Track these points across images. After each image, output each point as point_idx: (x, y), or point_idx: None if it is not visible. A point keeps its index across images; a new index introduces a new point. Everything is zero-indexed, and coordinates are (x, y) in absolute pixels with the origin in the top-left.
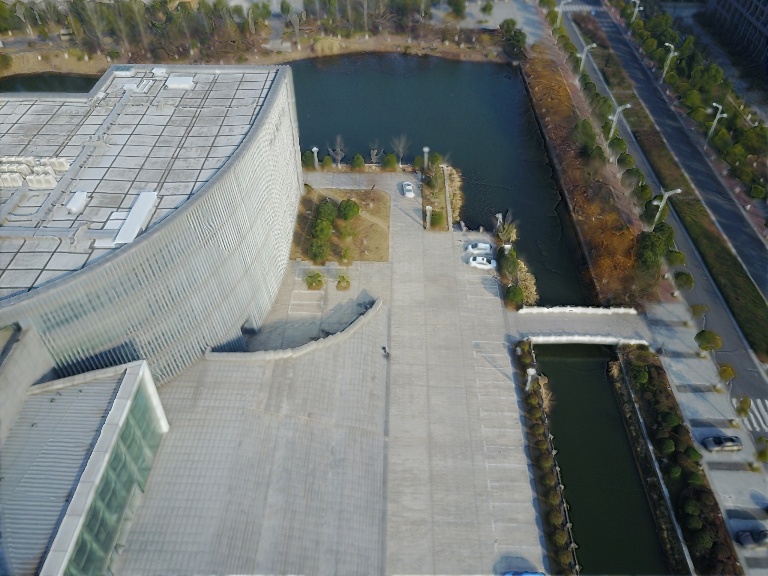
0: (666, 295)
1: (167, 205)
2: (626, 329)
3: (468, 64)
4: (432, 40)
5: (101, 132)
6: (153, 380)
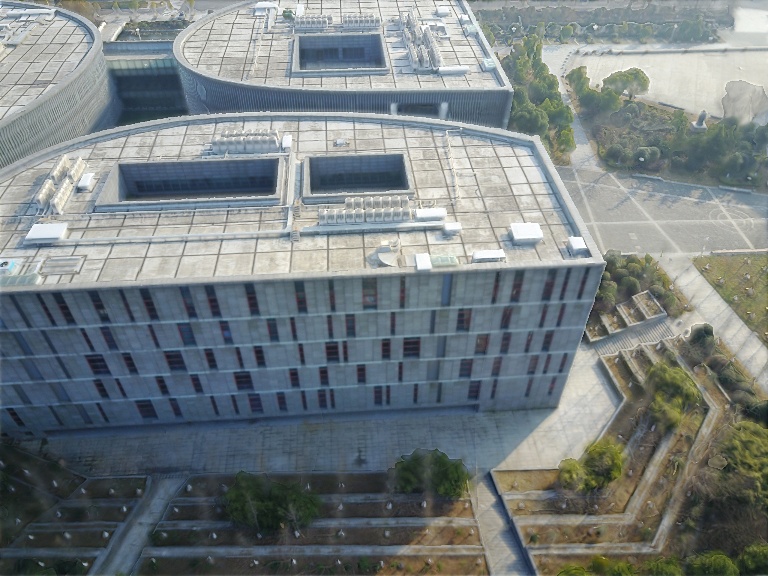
0: (97, 18)
1: None
2: (115, 26)
3: None
4: None
5: None
6: None
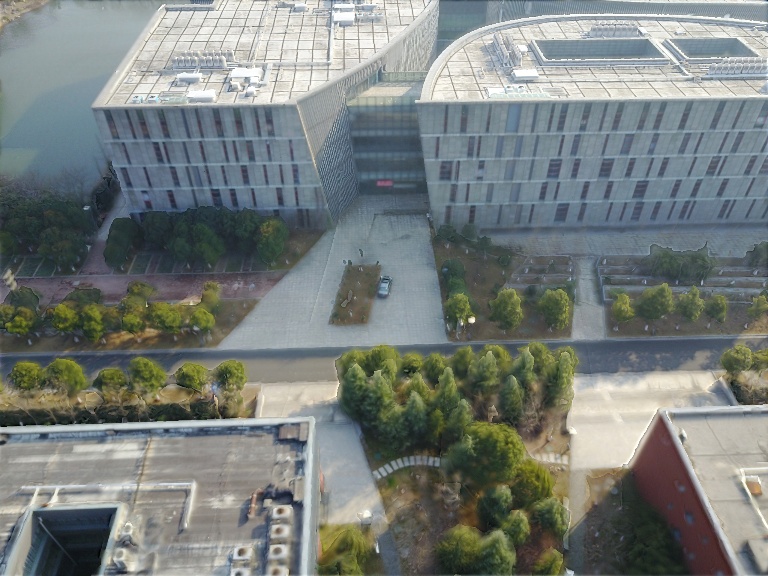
0: None
1: None
2: None
3: (46, 6)
4: (3, 8)
5: None
6: None
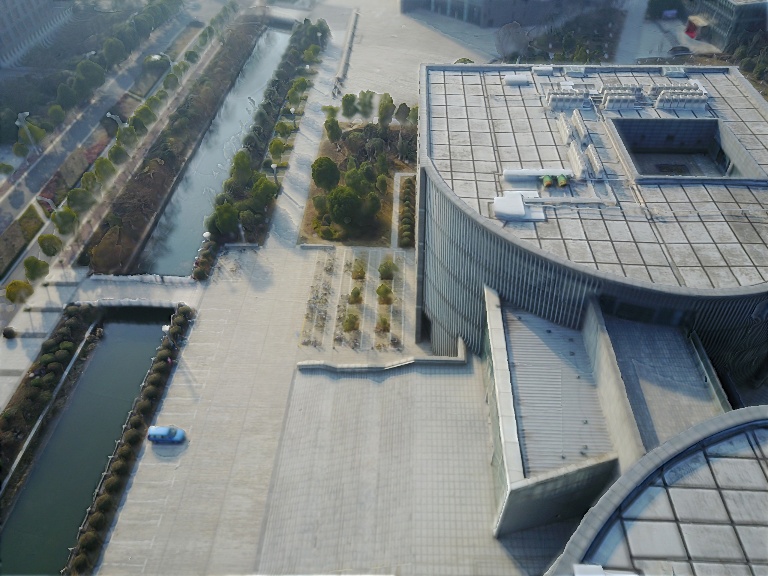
0: None
1: None
2: None
3: None
4: None
5: None
6: (506, 509)
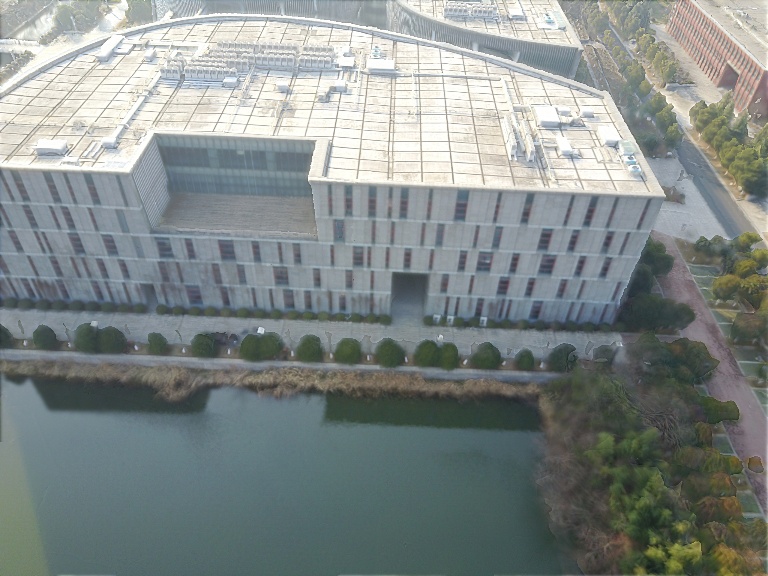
0: None
1: (91, 56)
2: None
3: None
4: None
5: (139, 100)
6: None
